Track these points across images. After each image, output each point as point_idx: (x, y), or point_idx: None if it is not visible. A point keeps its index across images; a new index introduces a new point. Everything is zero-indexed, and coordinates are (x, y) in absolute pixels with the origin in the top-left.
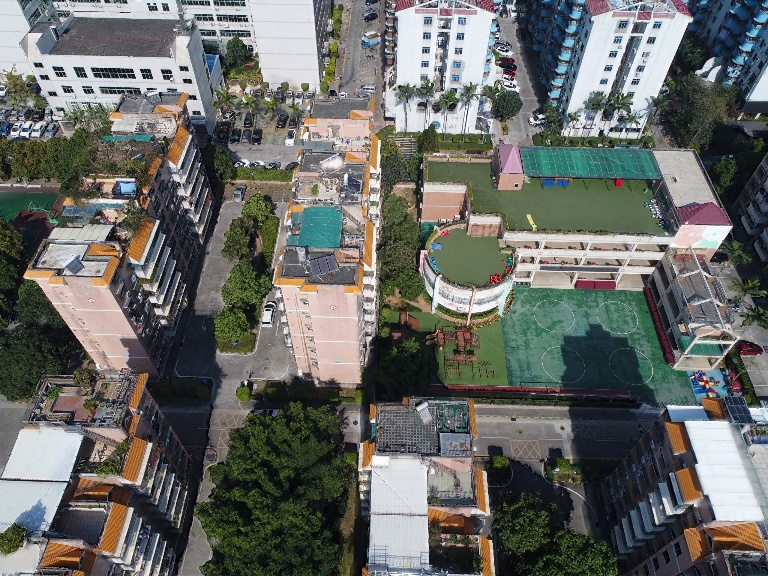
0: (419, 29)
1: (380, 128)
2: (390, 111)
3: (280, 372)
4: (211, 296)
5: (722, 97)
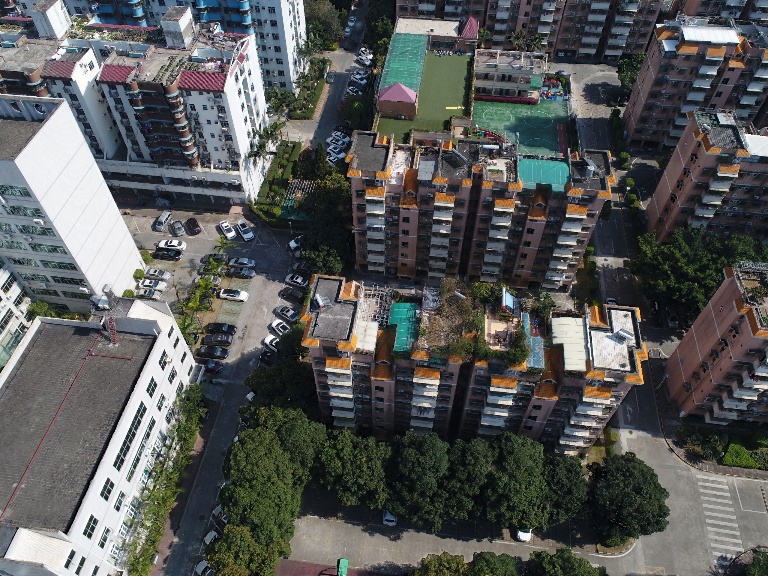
0: (236, 91)
1: (239, 218)
2: (246, 190)
3: (566, 307)
4: None
5: (310, 2)
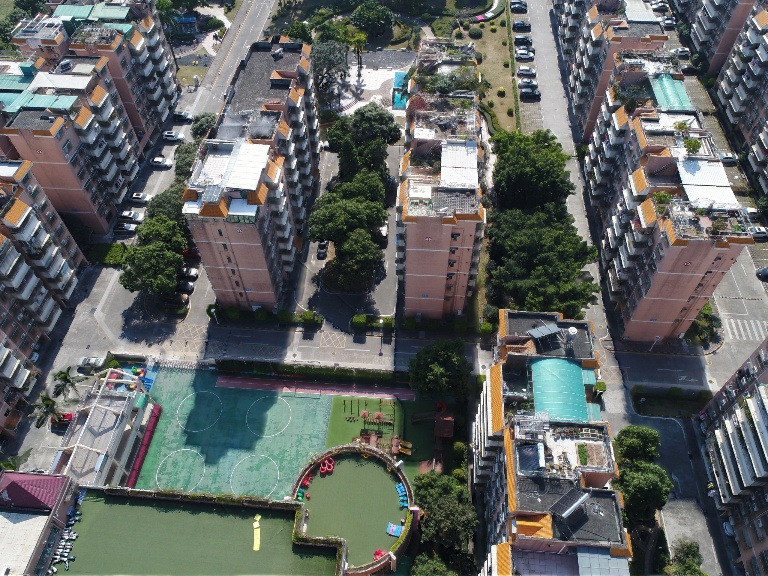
0: None
1: None
2: None
3: None
4: (689, 528)
5: None
